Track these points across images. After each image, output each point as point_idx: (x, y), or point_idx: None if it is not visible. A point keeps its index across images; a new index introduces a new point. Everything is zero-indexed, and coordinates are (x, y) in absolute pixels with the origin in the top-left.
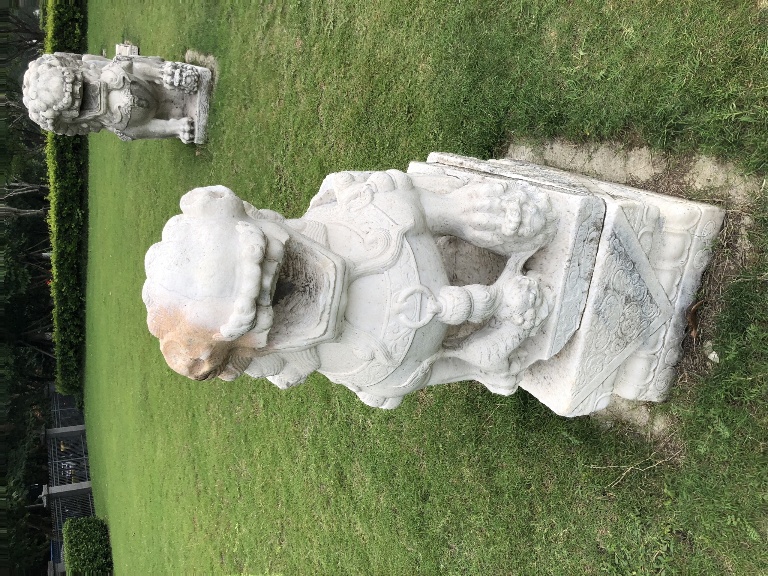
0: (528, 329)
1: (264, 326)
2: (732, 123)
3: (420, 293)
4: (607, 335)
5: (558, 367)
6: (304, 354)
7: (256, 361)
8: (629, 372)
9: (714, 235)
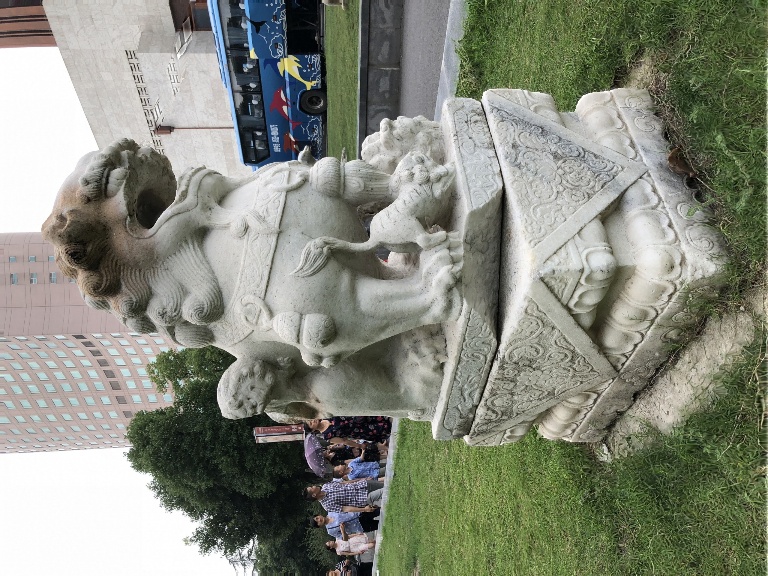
0: (425, 183)
1: (116, 174)
2: (599, 45)
3: (288, 171)
4: (548, 186)
5: (514, 243)
6: (191, 259)
7: (155, 292)
8: (634, 239)
9: (648, 106)
